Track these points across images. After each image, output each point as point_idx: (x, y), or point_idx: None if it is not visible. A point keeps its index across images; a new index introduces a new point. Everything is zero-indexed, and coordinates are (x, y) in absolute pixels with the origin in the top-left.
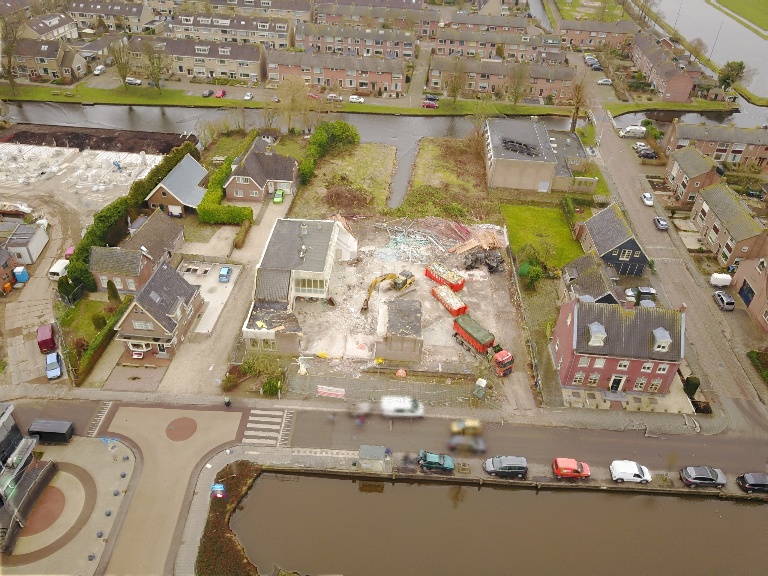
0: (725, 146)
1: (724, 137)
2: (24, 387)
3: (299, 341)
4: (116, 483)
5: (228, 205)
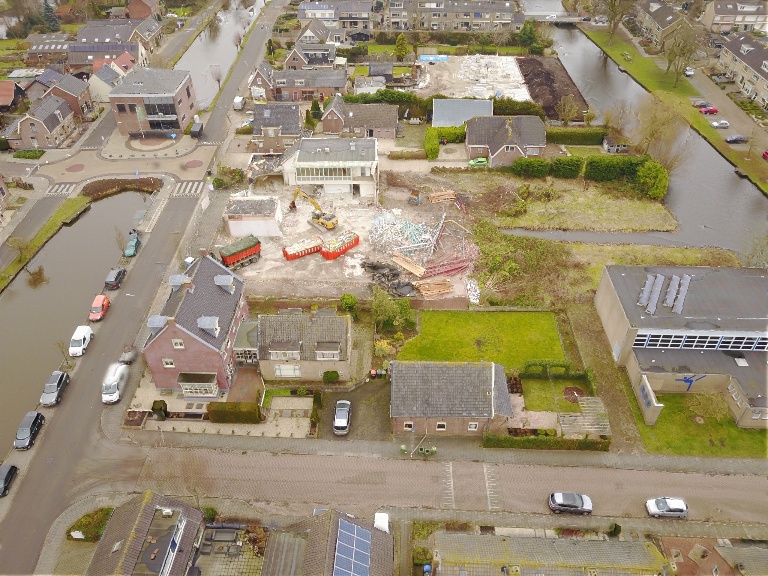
0: None
1: None
2: (239, 122)
3: (249, 180)
4: (162, 154)
5: None
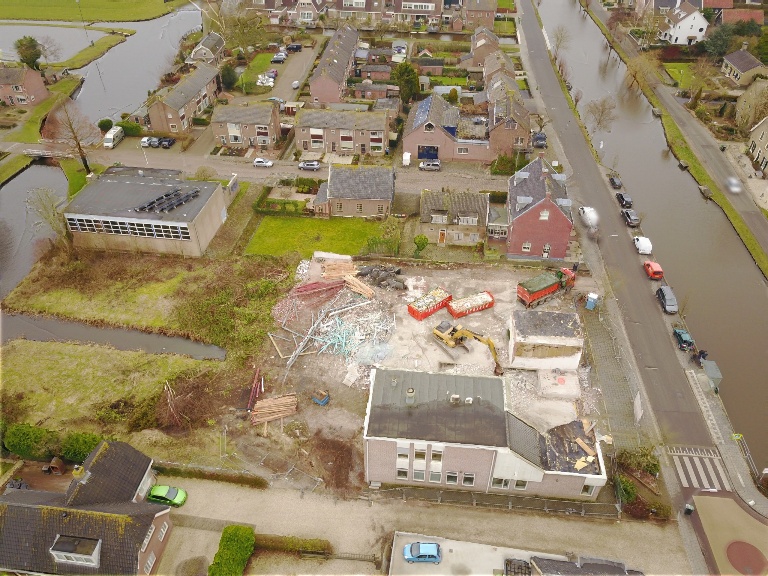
0: (198, 97)
1: (193, 90)
2: None
3: None
4: None
5: (212, 569)
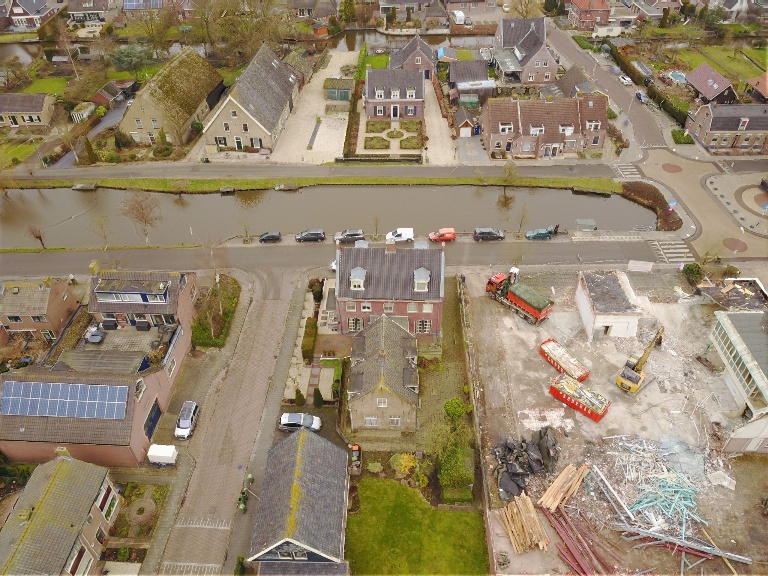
0: None
1: None
2: None
3: None
4: (742, 216)
5: None
